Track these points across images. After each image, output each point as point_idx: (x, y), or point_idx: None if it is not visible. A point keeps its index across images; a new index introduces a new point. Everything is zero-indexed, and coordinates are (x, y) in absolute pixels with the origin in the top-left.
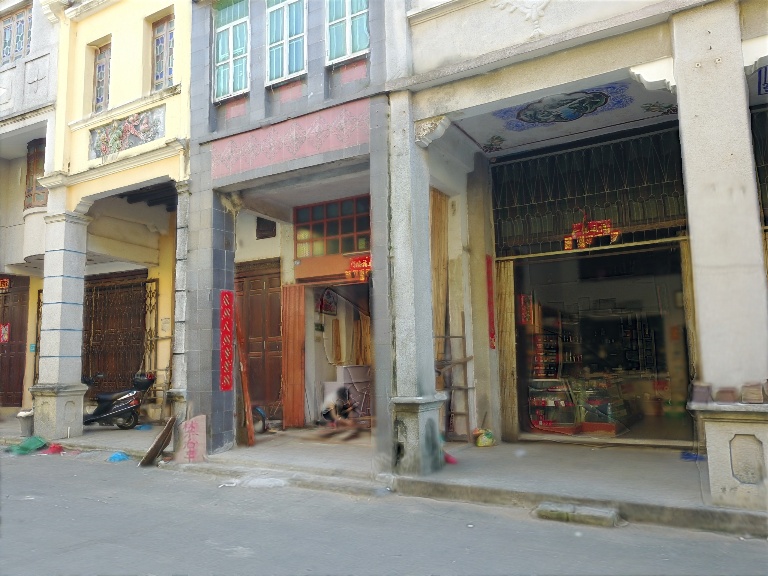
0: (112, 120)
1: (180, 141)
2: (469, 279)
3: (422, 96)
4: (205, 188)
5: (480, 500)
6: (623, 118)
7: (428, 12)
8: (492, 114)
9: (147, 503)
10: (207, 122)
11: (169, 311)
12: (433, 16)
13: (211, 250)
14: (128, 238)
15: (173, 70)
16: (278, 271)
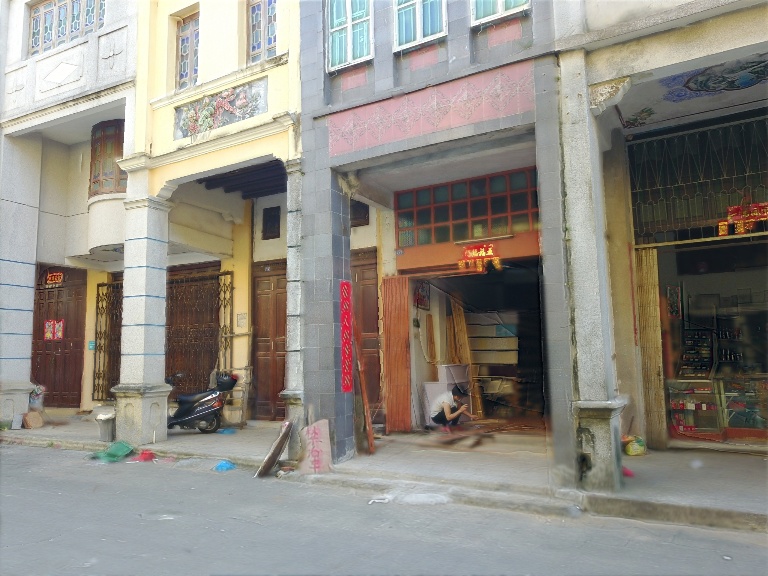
0: (203, 96)
1: (290, 115)
2: (608, 269)
3: (599, 56)
4: (321, 167)
5: (704, 523)
6: None
7: None
8: (659, 80)
9: (311, 525)
10: (322, 94)
11: (246, 306)
12: None
13: (330, 236)
14: (204, 227)
15: (276, 38)
16: (372, 262)
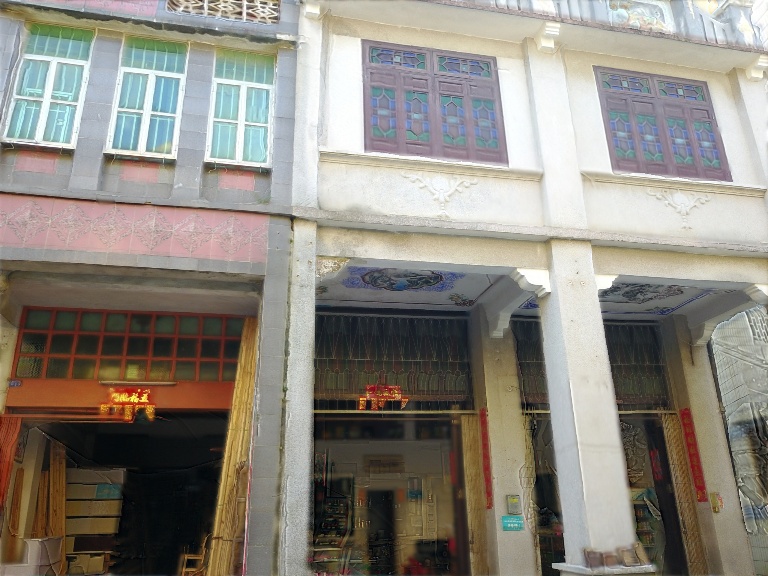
0: None
1: None
2: None
3: (326, 232)
4: None
5: None
6: (429, 300)
7: (341, 156)
8: (348, 267)
9: None
10: None
11: None
12: (344, 161)
13: None
14: None
15: None
16: None
